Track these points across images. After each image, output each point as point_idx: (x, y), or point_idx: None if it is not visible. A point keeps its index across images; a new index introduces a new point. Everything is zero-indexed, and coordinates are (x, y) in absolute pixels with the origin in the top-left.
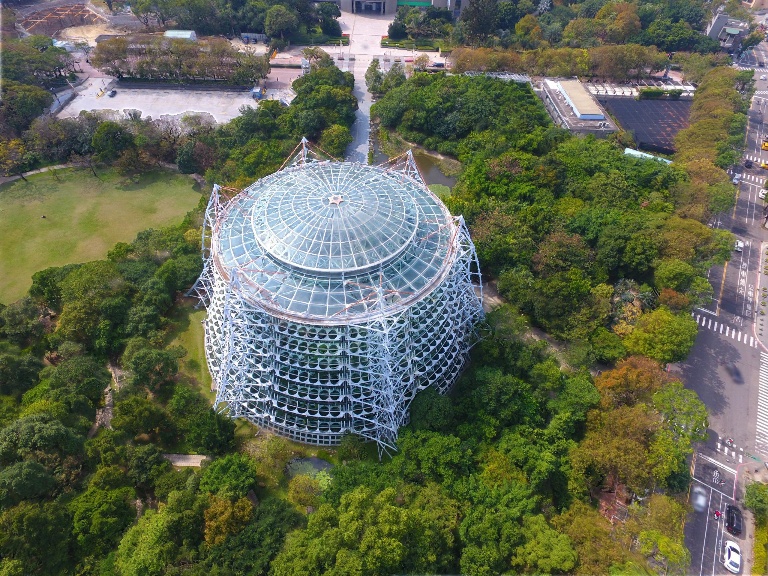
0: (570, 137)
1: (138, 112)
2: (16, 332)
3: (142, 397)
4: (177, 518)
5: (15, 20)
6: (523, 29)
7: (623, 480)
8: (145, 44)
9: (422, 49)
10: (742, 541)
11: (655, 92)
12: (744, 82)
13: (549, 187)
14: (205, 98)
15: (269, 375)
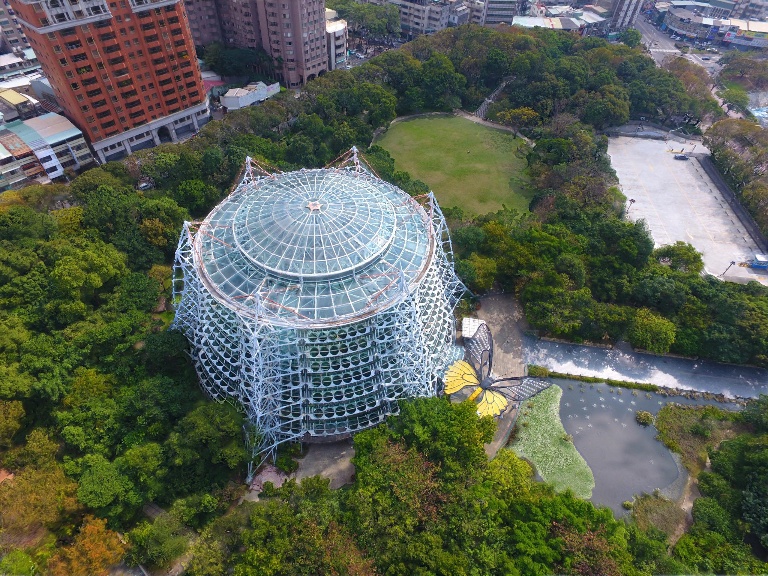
0: None
1: (609, 160)
2: None
3: None
4: (158, 207)
5: (767, 79)
6: None
7: None
8: (761, 144)
9: None
10: None
11: None
12: None
13: None
14: (718, 219)
15: None
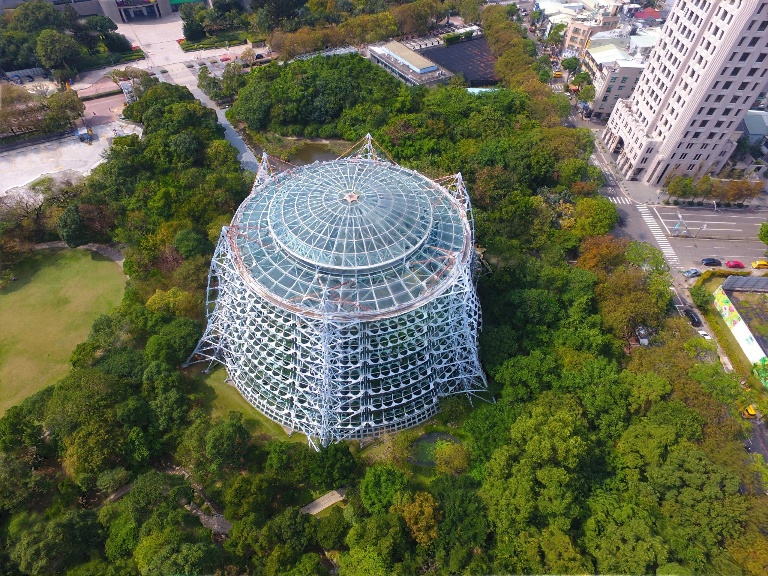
0: (428, 91)
1: None
2: (18, 501)
3: (236, 477)
4: (392, 539)
5: None
6: (317, 5)
7: (641, 323)
8: None
9: (229, 45)
10: (703, 328)
11: (455, 37)
12: (512, 14)
13: (445, 136)
14: (19, 159)
15: (357, 385)
